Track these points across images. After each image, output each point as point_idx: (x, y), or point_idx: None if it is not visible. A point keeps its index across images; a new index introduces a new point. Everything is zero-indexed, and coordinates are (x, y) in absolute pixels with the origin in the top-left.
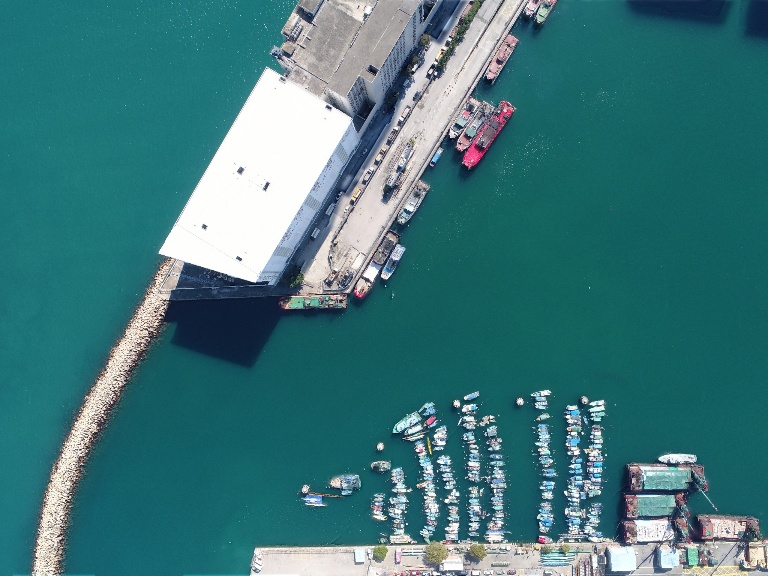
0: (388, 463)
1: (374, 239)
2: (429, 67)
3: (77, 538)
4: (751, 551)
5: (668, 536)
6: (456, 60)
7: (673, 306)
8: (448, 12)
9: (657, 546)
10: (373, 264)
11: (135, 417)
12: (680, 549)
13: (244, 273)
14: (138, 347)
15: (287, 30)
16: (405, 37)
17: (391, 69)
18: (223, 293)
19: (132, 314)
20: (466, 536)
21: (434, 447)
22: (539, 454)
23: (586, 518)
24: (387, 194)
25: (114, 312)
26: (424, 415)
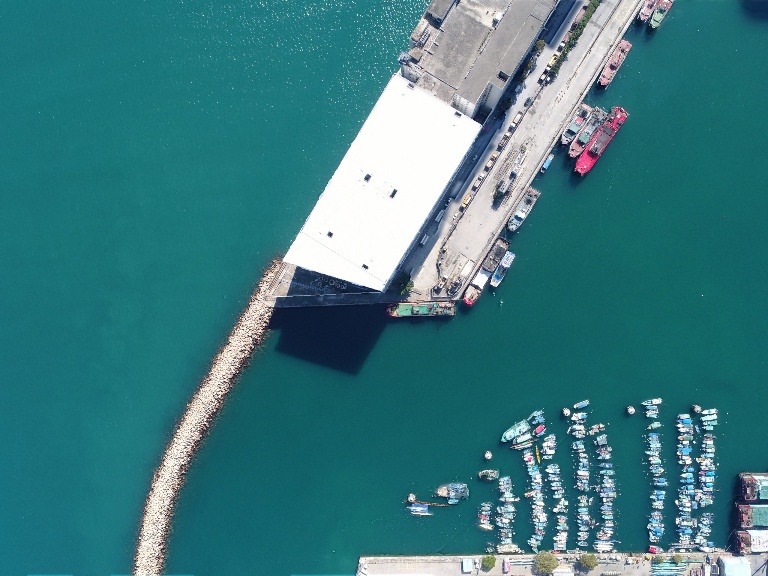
0: (496, 472)
1: (483, 246)
2: (542, 72)
3: (177, 547)
4: None
5: None
6: (568, 65)
7: None
8: (560, 17)
9: None
10: (483, 271)
11: None
12: None
13: (370, 281)
14: (242, 354)
15: (416, 36)
16: (531, 43)
17: (512, 75)
18: (329, 300)
19: (235, 321)
20: (575, 546)
21: (543, 456)
22: (650, 463)
23: (697, 528)
24: (497, 200)
25: (217, 319)
26: (533, 423)
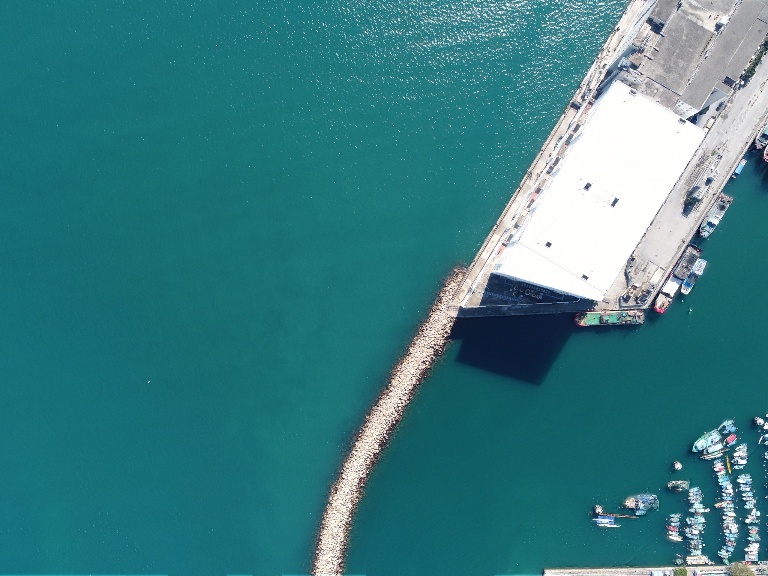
0: (687, 482)
1: (673, 253)
2: None
3: (354, 560)
4: None
5: None
6: (762, 69)
7: None
8: None
9: None
10: (674, 279)
11: None
12: None
13: (589, 292)
14: (423, 365)
15: (638, 41)
16: None
17: None
18: (514, 310)
19: (415, 332)
20: (767, 557)
21: (734, 466)
22: None
23: None
24: (688, 207)
25: (397, 330)
26: (724, 433)
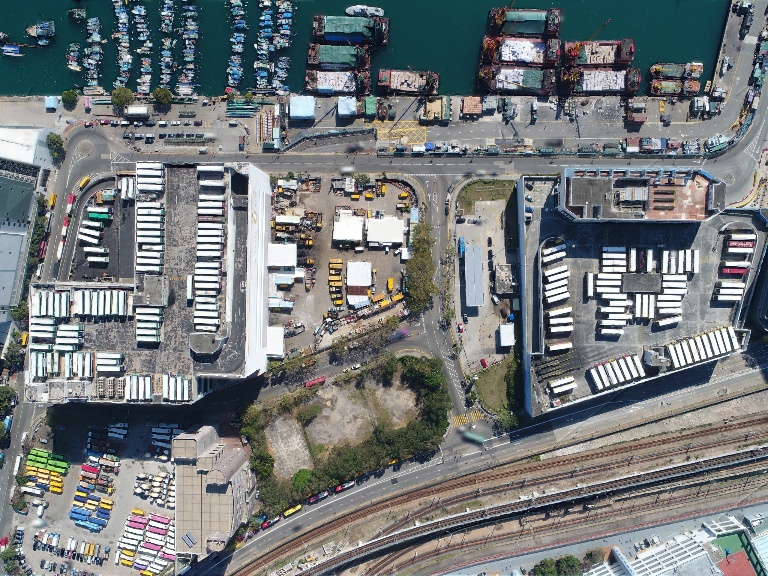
0: (83, 9)
1: None
2: None
3: None
4: (430, 104)
5: (350, 87)
6: None
7: None
8: None
9: None
10: None
11: None
12: None
13: None
14: None
15: None
16: None
17: None
18: None
19: None
20: None
21: None
22: (231, 6)
23: (274, 72)
24: None
25: None
26: None
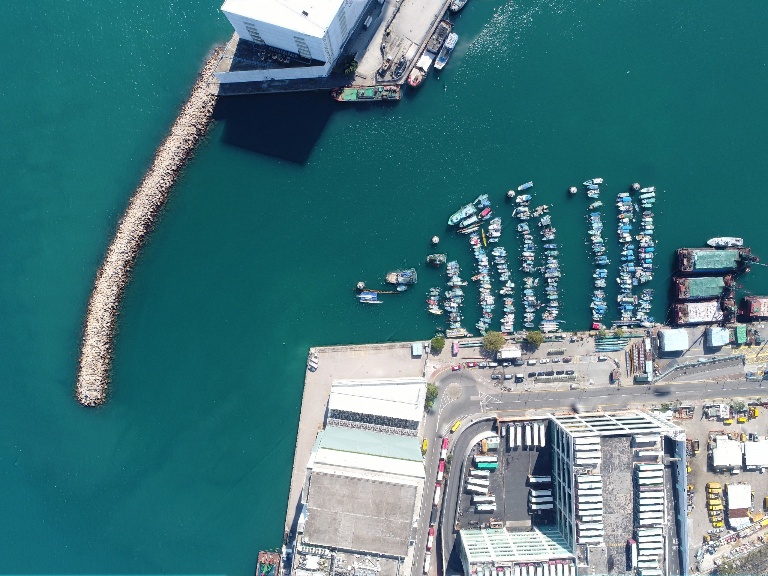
0: (444, 255)
1: (427, 29)
2: None
3: (124, 348)
4: None
5: (717, 317)
6: None
7: (719, 92)
8: None
9: (707, 327)
10: (427, 53)
11: (182, 221)
12: (729, 329)
13: (310, 29)
14: (186, 145)
15: None
16: None
17: None
18: (274, 86)
19: (178, 112)
20: (521, 327)
21: (489, 239)
22: (592, 242)
23: (638, 304)
24: None
25: (159, 110)
26: (479, 207)
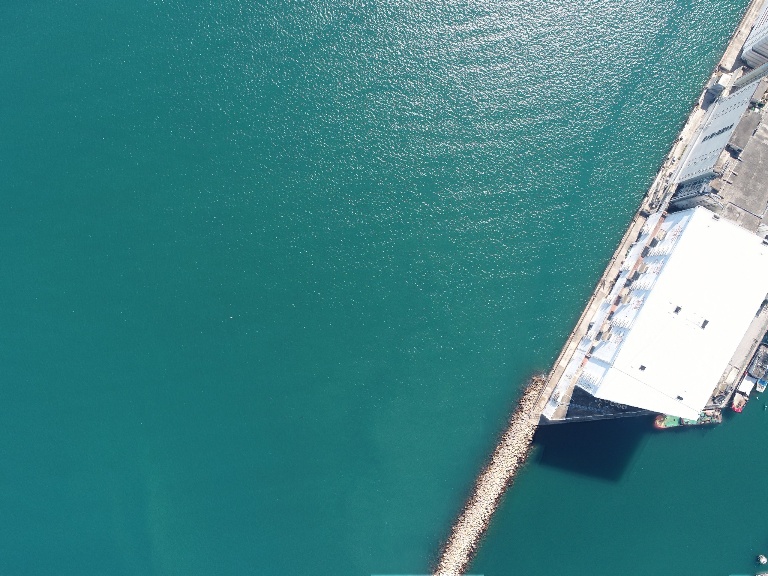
0: None
1: (747, 352)
2: None
3: None
4: None
5: None
6: None
7: None
8: None
9: None
10: (749, 378)
11: None
12: None
13: (684, 412)
14: (507, 474)
15: (718, 168)
16: None
17: None
18: None
19: (497, 440)
20: None
21: None
22: None
23: None
24: None
25: (479, 439)
26: None
